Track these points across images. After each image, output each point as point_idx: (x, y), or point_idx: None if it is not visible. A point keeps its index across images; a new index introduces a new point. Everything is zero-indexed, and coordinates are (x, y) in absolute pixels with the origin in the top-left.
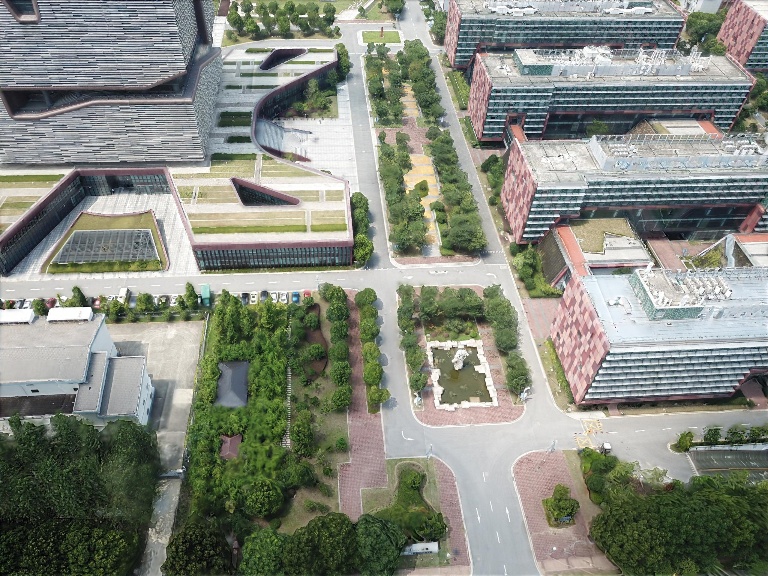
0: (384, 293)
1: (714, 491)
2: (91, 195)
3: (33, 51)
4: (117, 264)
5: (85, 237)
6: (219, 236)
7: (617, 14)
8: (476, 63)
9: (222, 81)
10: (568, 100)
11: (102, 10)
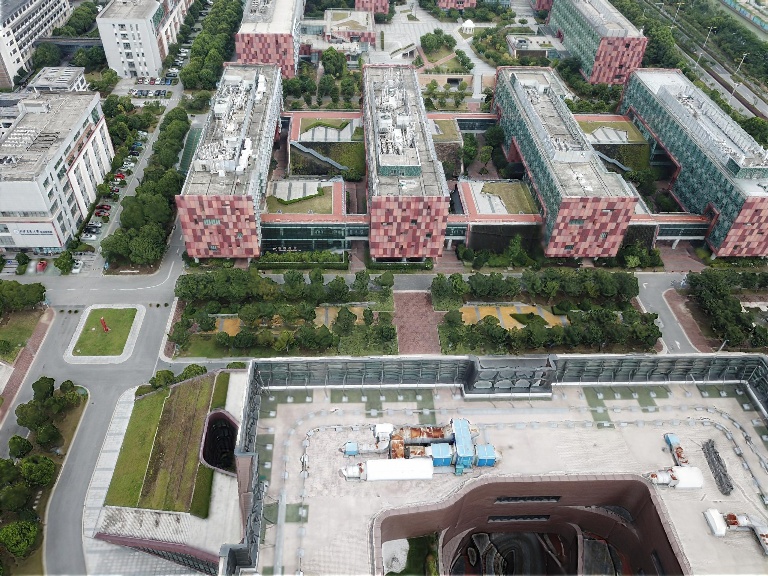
0: None
1: None
2: None
3: None
4: None
5: None
6: None
7: (263, 96)
8: (380, 205)
9: None
10: None
11: None
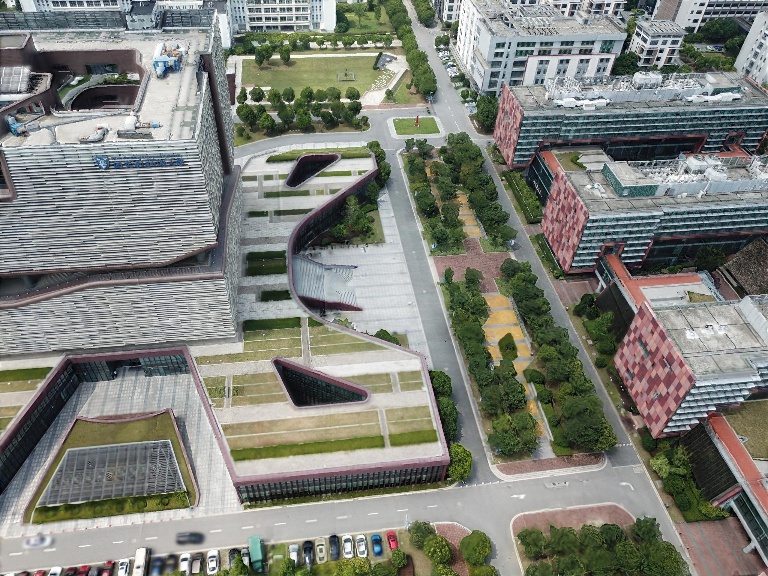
0: (493, 527)
1: None
2: (87, 381)
3: (6, 232)
4: (129, 504)
5: (82, 459)
6: (268, 463)
7: (701, 102)
8: (557, 179)
9: (243, 205)
10: (676, 225)
11: (103, 180)
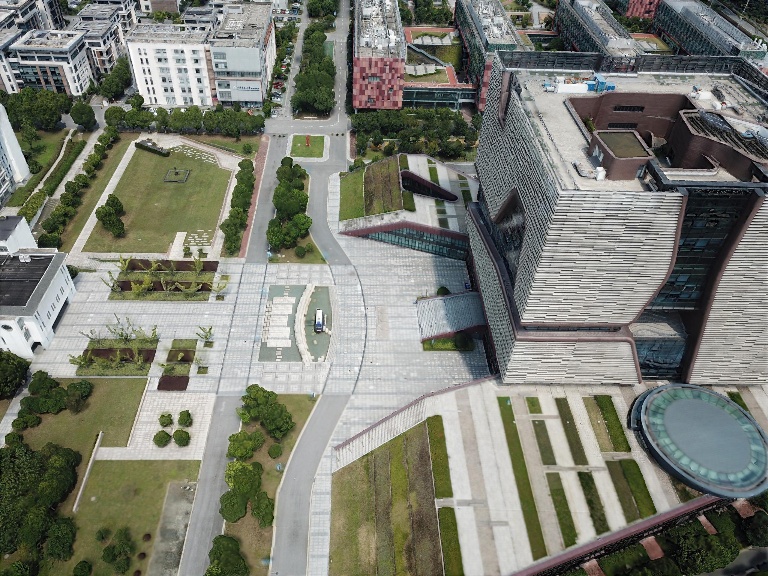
0: None
1: None
2: None
3: None
4: None
5: None
6: None
7: (390, 8)
8: None
9: None
10: None
11: None
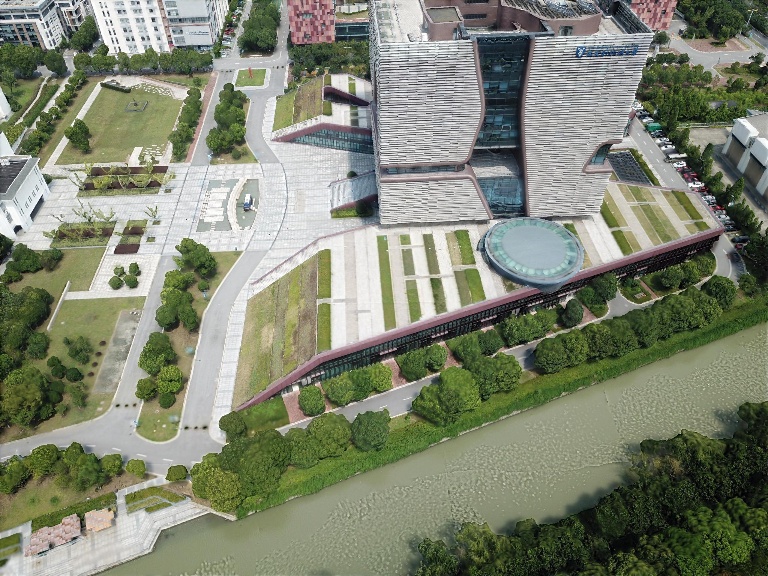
0: None
1: (706, 1)
2: None
3: None
4: None
5: None
6: None
7: None
8: None
9: None
10: None
11: None
